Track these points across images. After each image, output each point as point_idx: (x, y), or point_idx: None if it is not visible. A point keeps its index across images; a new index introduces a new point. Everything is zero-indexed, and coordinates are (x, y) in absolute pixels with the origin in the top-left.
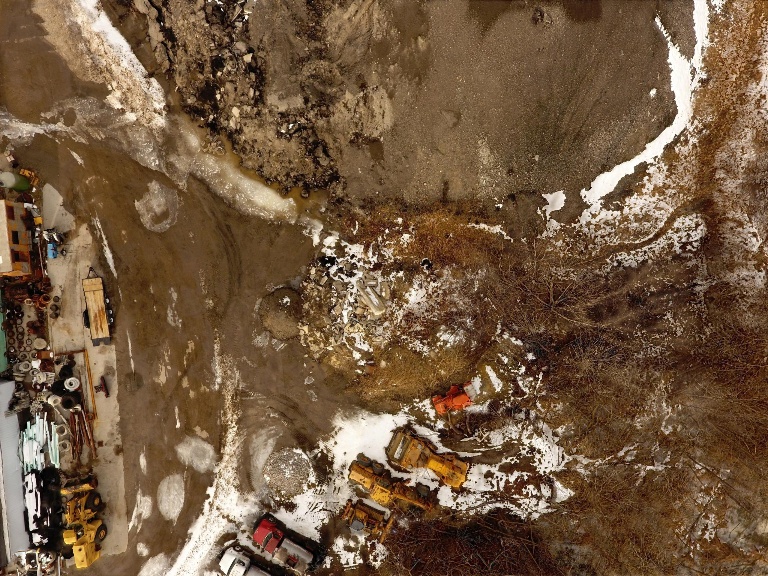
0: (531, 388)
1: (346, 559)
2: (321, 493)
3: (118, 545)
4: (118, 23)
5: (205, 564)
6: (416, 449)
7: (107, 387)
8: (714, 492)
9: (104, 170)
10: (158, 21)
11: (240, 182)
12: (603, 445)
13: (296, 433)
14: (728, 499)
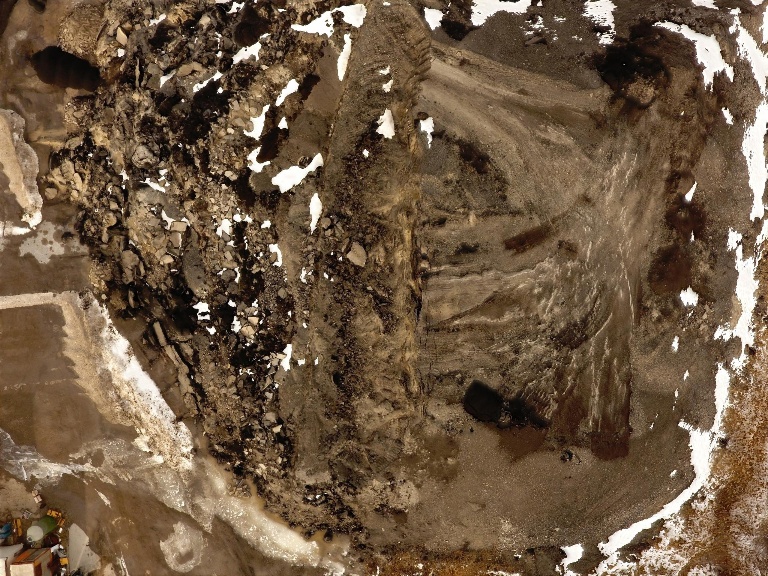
0: None
1: None
2: None
3: None
4: (148, 367)
5: None
6: None
7: None
8: None
9: (130, 511)
10: (188, 376)
11: (264, 525)
12: None
13: None
14: None
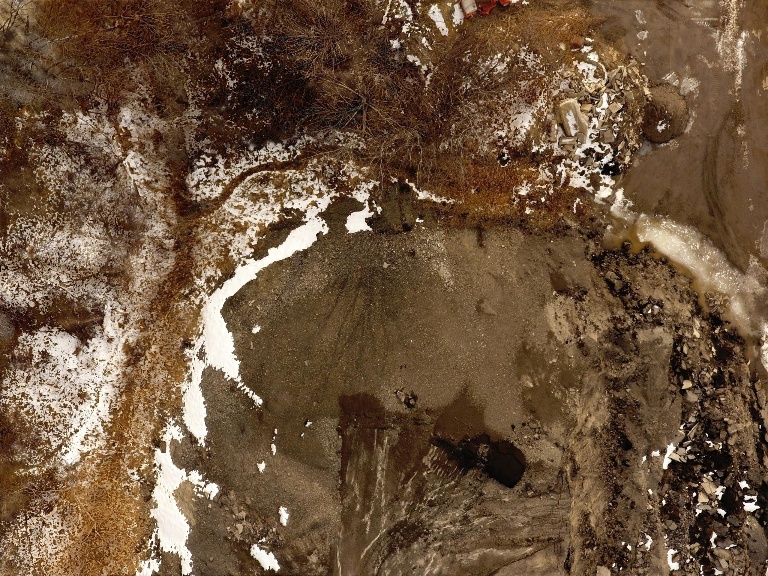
0: (397, 6)
1: None
2: None
3: None
4: None
5: None
6: None
7: None
8: None
9: None
10: (765, 430)
11: (694, 262)
12: None
13: None
14: None
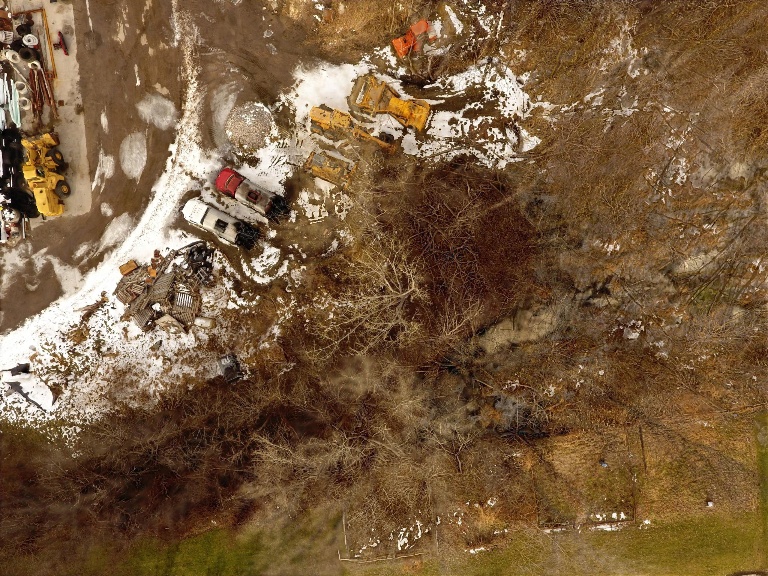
0: (492, 28)
1: (311, 212)
2: (284, 147)
3: (82, 205)
4: None
5: (170, 223)
6: (377, 88)
7: (65, 43)
8: (684, 135)
9: None
10: None
11: None
12: (569, 92)
13: (257, 87)
14: (699, 143)
